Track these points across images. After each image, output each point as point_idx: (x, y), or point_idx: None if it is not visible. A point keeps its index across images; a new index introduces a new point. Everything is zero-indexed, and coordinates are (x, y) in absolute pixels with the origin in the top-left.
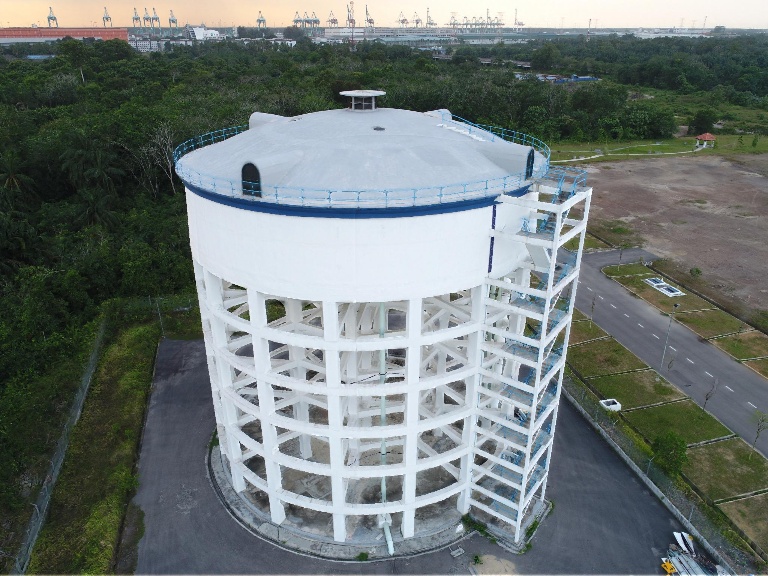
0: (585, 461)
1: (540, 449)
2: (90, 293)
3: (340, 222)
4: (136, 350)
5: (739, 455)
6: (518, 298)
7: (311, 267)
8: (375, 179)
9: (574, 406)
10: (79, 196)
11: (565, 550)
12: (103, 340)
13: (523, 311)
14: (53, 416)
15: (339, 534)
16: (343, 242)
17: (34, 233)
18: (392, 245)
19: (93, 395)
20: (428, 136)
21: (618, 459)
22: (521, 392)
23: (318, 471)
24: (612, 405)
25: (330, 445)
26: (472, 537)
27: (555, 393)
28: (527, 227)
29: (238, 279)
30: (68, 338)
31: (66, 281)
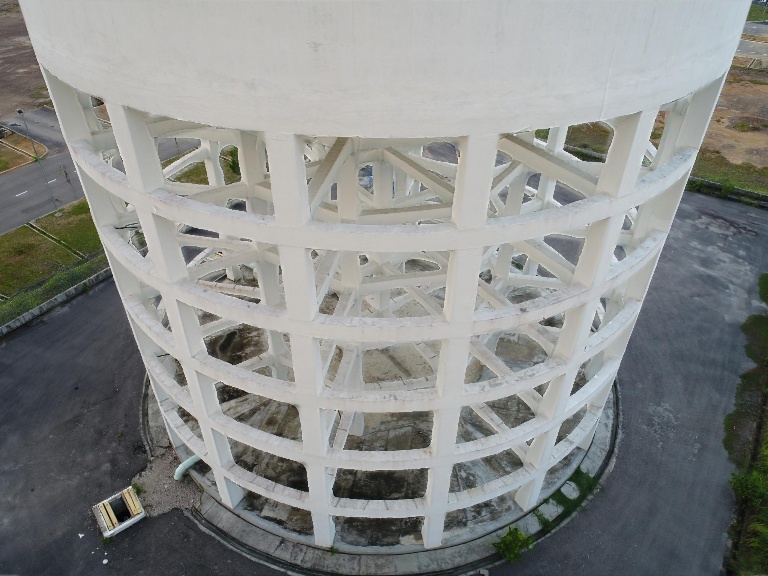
0: None
1: None
2: None
3: None
4: None
5: None
6: None
7: None
8: None
9: None
10: None
11: None
12: None
13: None
14: None
15: None
16: None
17: None
18: None
19: None
20: None
21: None
22: None
23: None
24: None
25: None
26: None
27: None
28: None
29: None
30: None
31: None
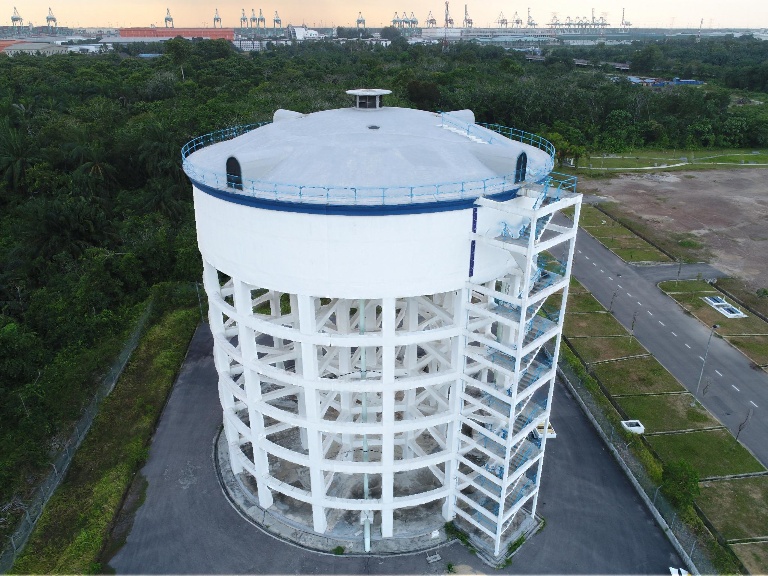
0: (590, 482)
1: (525, 463)
2: (146, 276)
3: (312, 218)
4: (175, 332)
5: (767, 494)
6: (500, 305)
7: (286, 260)
8: (353, 177)
9: (592, 424)
10: (148, 185)
11: (547, 571)
12: (149, 320)
13: (501, 318)
14: (91, 386)
15: (318, 525)
16: (316, 237)
17: (103, 217)
18: (364, 243)
19: (129, 370)
20: (421, 136)
21: (627, 484)
22: (503, 402)
23: (298, 461)
24: (634, 427)
25: (308, 436)
26: (452, 545)
27: None
28: (509, 232)
29: (226, 268)
30: (117, 316)
31: (123, 263)
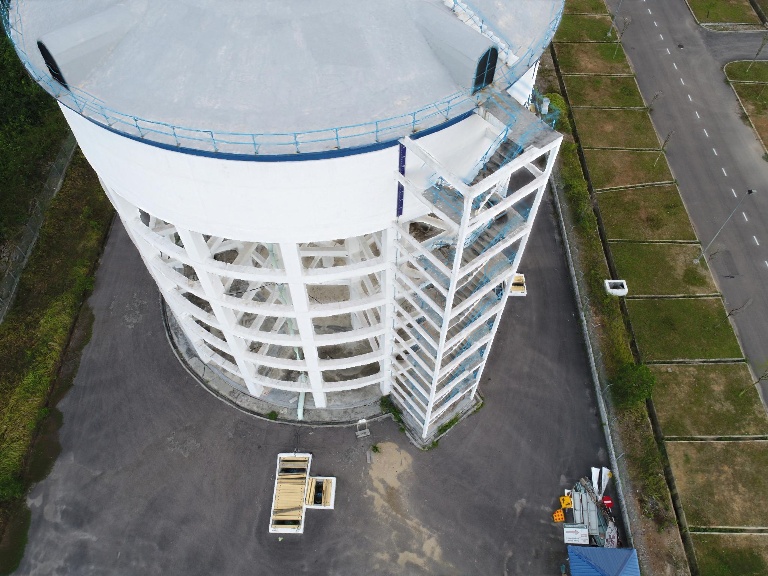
0: (546, 357)
1: (461, 375)
2: None
3: (166, 151)
4: None
5: (731, 387)
6: (436, 249)
7: (150, 189)
8: (223, 85)
9: (571, 281)
10: None
11: (470, 456)
12: None
13: (429, 277)
14: (39, 179)
15: (253, 392)
16: (178, 173)
17: None
18: (242, 187)
19: (77, 161)
20: None
21: (585, 362)
22: (436, 334)
23: (221, 349)
24: (617, 289)
25: None
26: (384, 420)
27: (490, 329)
28: None
29: (92, 165)
30: None
31: None
